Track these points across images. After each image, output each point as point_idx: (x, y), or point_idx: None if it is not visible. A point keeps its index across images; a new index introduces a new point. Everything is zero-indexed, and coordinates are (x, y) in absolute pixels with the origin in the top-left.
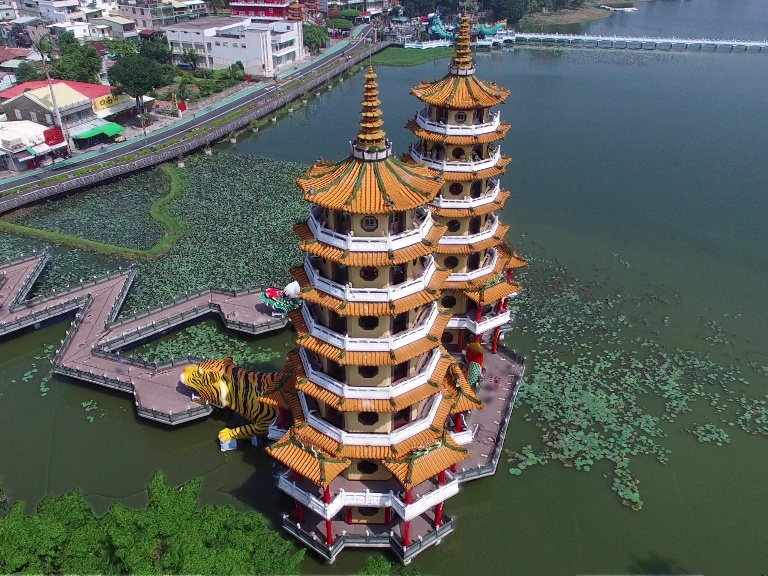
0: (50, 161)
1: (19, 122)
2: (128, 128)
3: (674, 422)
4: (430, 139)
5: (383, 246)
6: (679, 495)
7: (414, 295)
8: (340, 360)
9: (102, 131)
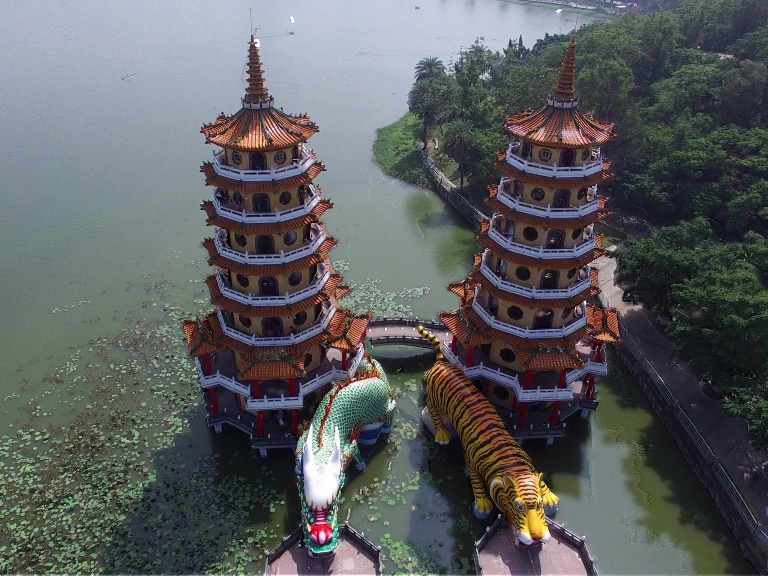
0: None
1: None
2: None
3: None
4: None
5: None
6: (404, 277)
7: None
8: None
9: None
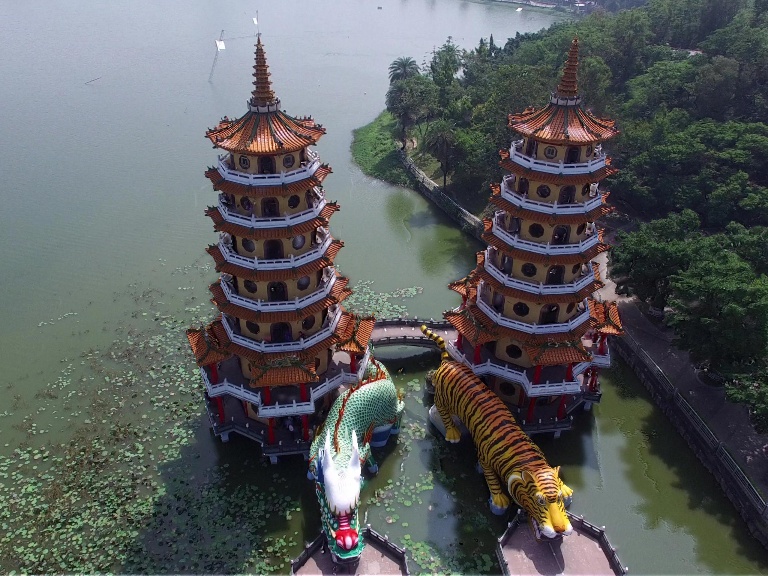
0: None
1: None
2: None
3: None
4: None
5: None
6: (396, 278)
7: None
8: None
9: None
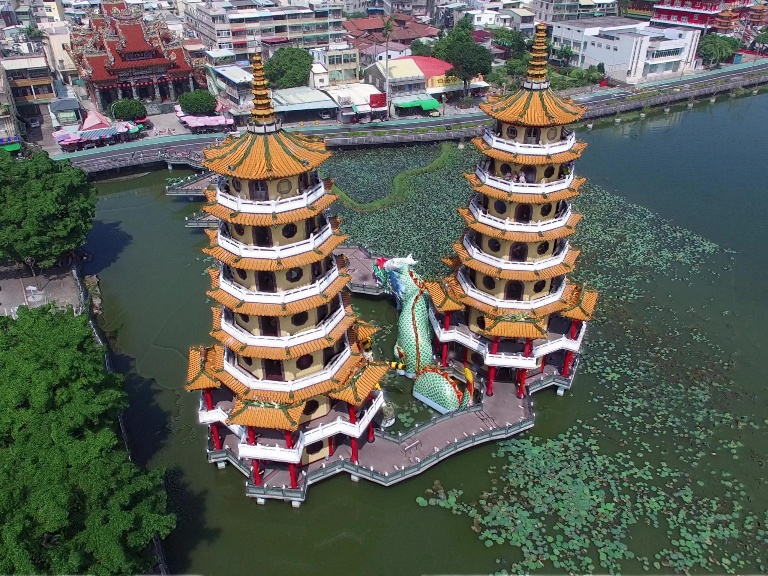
0: (368, 120)
1: (365, 85)
2: (452, 107)
3: (647, 570)
4: (479, 148)
5: (236, 206)
6: None
7: (266, 260)
8: (208, 292)
9: (421, 104)
